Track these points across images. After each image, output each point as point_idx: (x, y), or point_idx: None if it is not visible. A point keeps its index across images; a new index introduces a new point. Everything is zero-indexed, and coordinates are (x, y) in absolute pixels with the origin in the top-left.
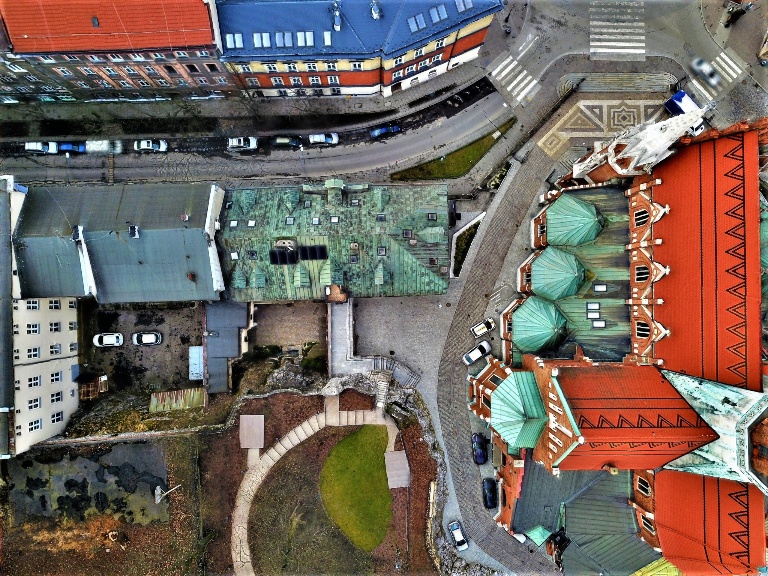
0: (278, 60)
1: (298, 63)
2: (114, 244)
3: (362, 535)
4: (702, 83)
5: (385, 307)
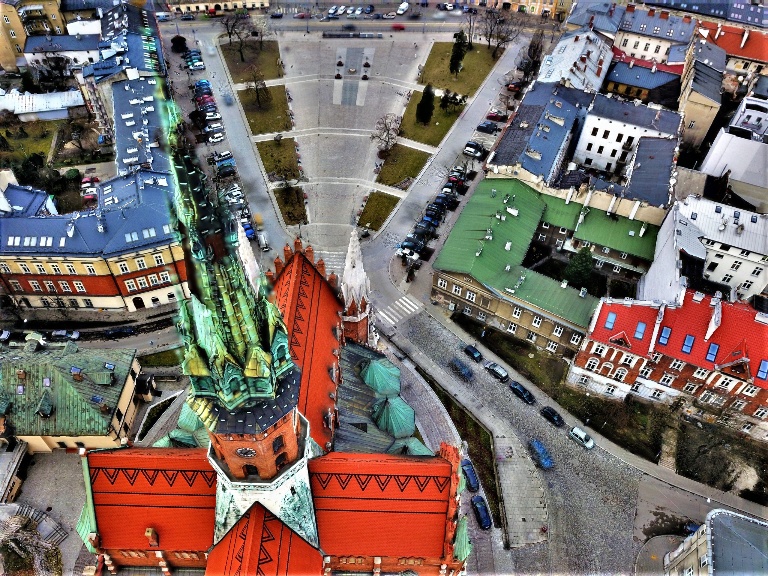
0: (26, 258)
1: (43, 263)
2: None
3: None
4: (387, 314)
5: (61, 466)
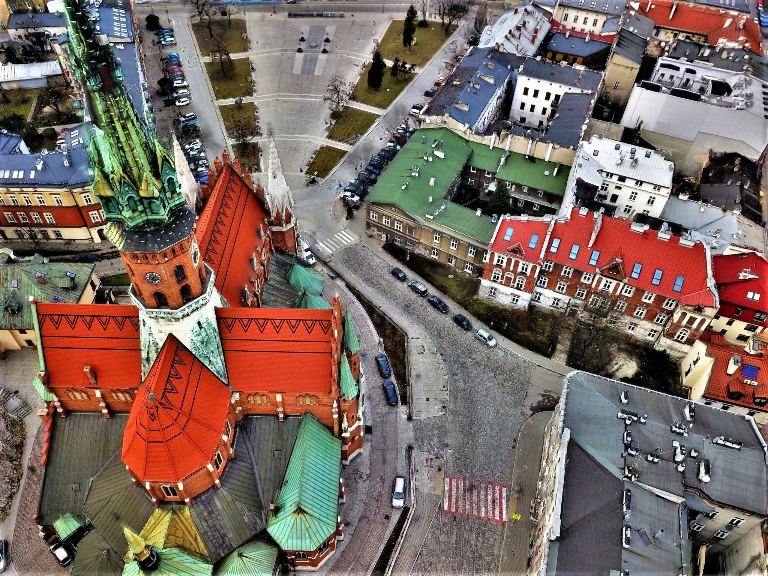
0: (1, 189)
1: (16, 194)
2: None
3: None
4: (326, 244)
5: (28, 360)
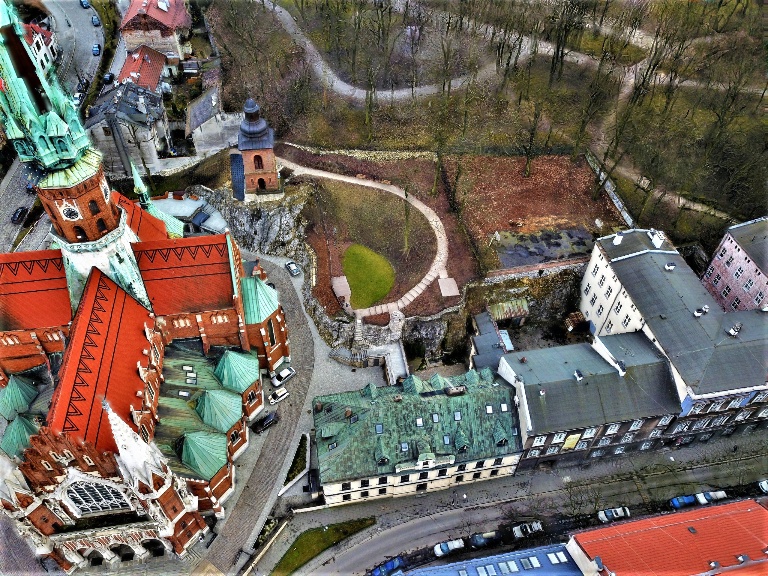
0: None
1: None
2: (591, 369)
3: (360, 251)
4: None
5: None
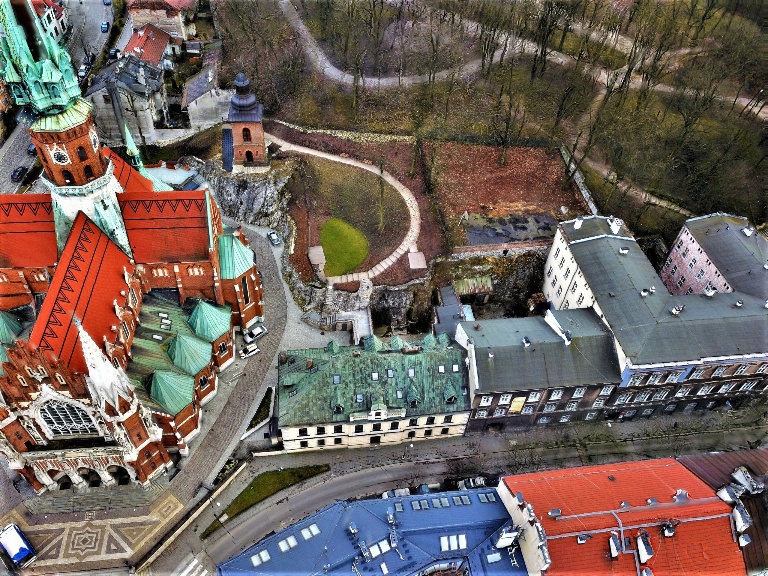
0: None
1: None
2: (540, 338)
3: (338, 225)
4: None
5: None
